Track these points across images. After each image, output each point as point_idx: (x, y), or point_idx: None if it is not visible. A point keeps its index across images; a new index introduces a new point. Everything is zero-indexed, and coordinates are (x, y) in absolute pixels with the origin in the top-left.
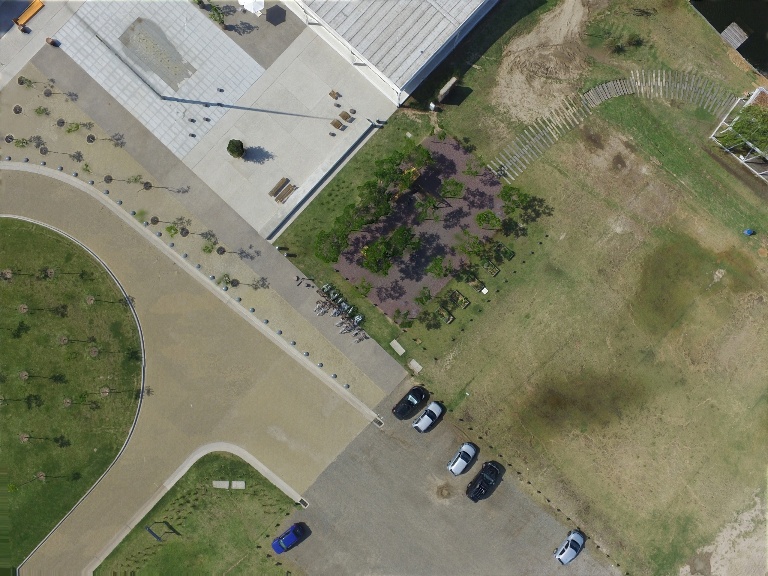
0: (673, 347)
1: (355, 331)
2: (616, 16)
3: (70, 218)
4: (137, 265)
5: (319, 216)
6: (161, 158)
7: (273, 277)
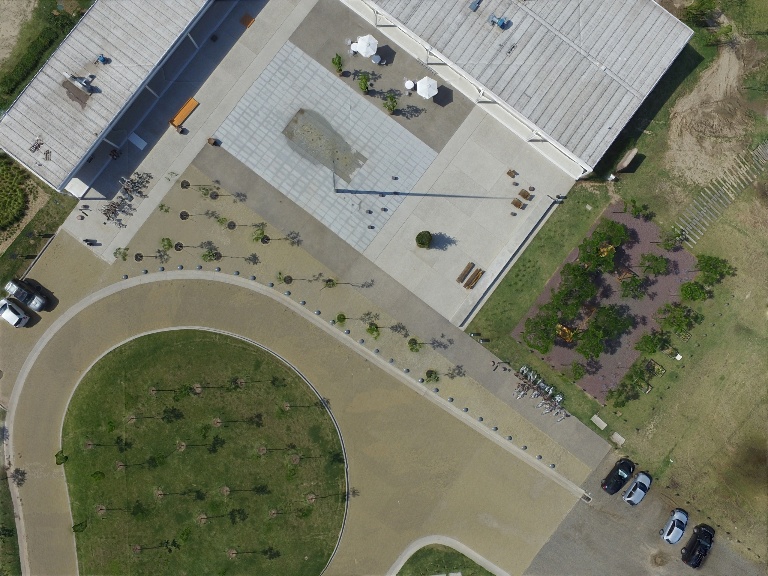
0: None
1: (557, 411)
2: None
3: (253, 324)
4: (328, 365)
5: (508, 298)
6: (341, 253)
7: (468, 364)
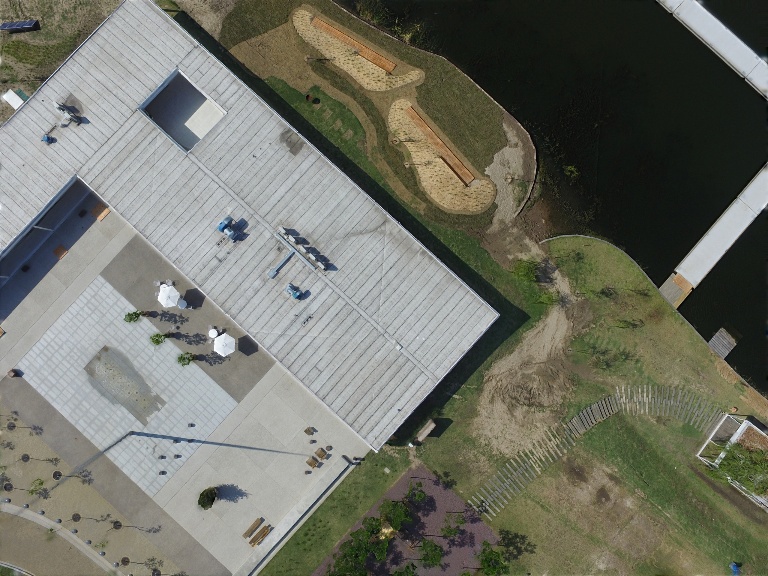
0: None
1: None
2: (601, 329)
3: (37, 558)
4: None
5: (295, 556)
6: (131, 496)
7: None
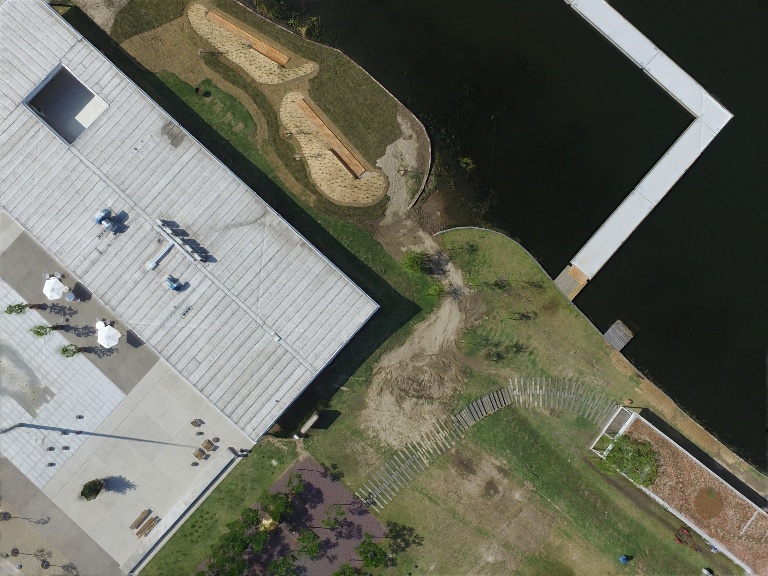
0: None
1: None
2: (494, 321)
3: None
4: None
5: (183, 548)
6: (20, 487)
7: None
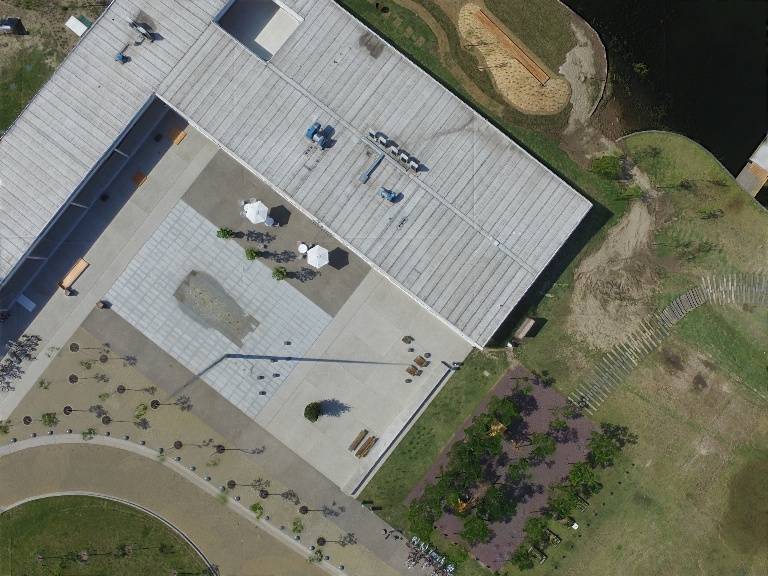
0: (763, 563)
1: None
2: (683, 222)
3: (142, 489)
4: (218, 532)
5: (401, 466)
6: (232, 419)
7: (360, 532)
